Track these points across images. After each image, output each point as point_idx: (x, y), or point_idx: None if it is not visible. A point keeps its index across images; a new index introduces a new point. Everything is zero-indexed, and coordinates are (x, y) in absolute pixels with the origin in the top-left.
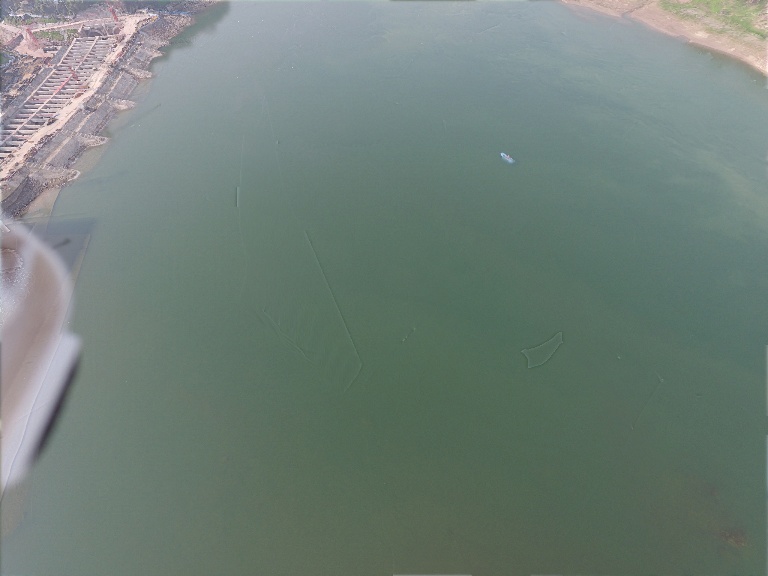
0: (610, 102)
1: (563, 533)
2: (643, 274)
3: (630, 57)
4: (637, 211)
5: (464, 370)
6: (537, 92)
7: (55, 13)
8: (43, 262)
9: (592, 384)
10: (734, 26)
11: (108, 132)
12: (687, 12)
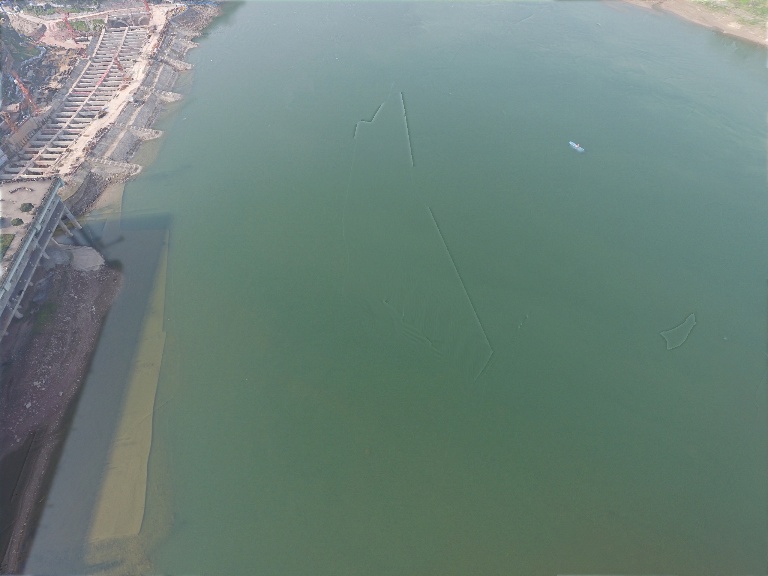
0: (661, 91)
1: (710, 508)
2: (738, 257)
3: (669, 47)
4: (706, 197)
5: (582, 355)
6: (587, 82)
7: (78, 2)
8: (126, 259)
9: (713, 364)
10: (765, 17)
11: (160, 125)
12: (717, 4)
